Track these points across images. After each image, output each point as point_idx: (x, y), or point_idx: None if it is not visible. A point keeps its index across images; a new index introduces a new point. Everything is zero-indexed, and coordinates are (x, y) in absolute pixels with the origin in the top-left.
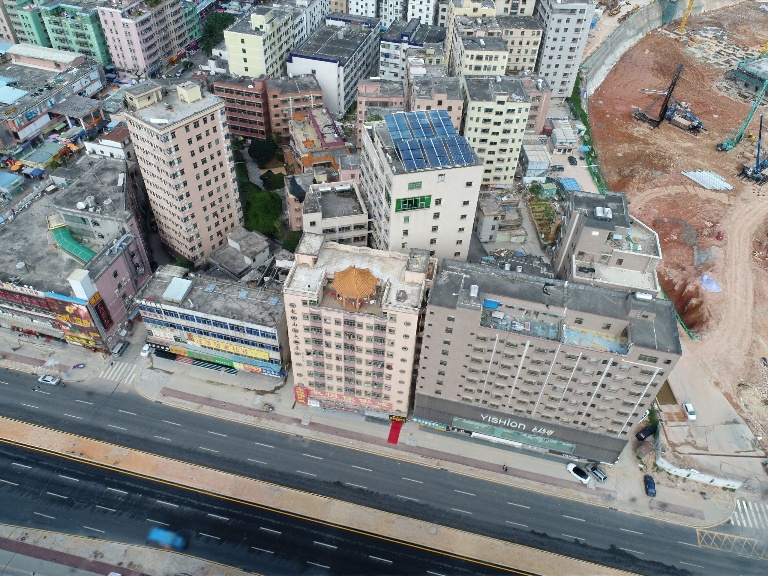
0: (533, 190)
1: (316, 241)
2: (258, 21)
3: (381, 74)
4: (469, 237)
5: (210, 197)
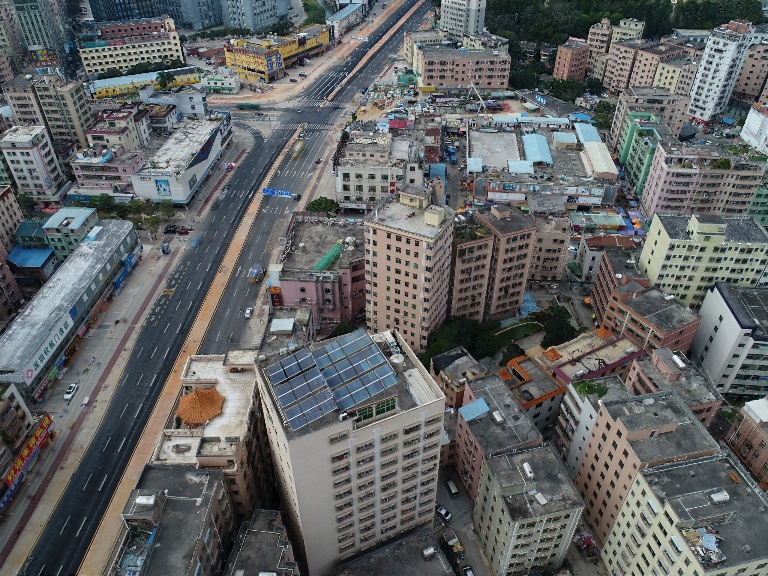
0: None
1: (247, 360)
2: (693, 225)
3: None
4: None
5: (396, 303)
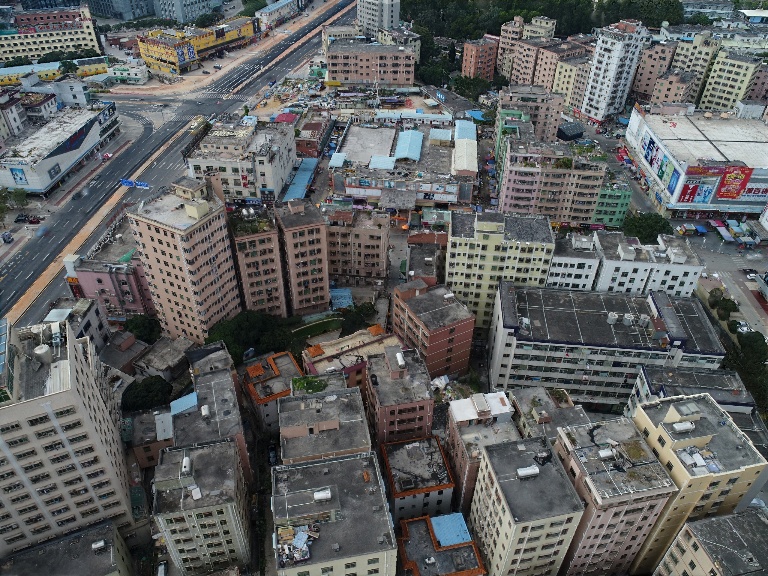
0: None
1: None
2: None
3: (627, 408)
4: None
5: (174, 296)
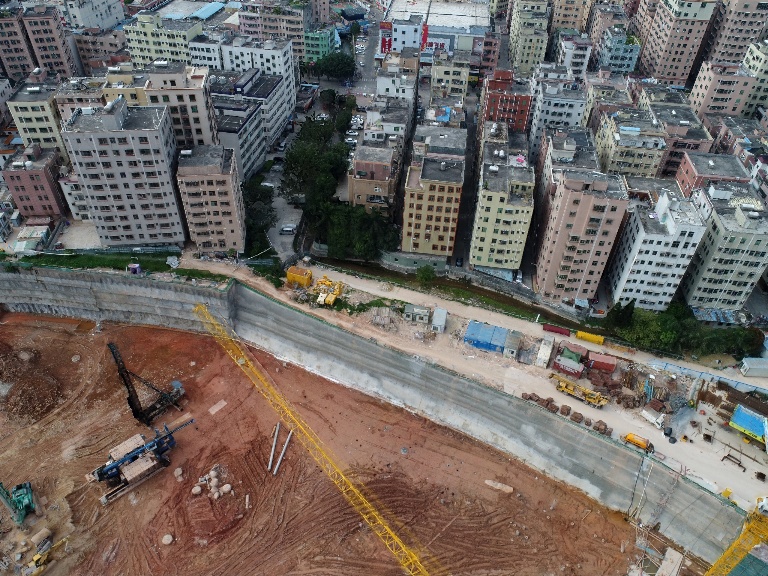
0: None
1: None
2: None
3: None
4: None
5: None
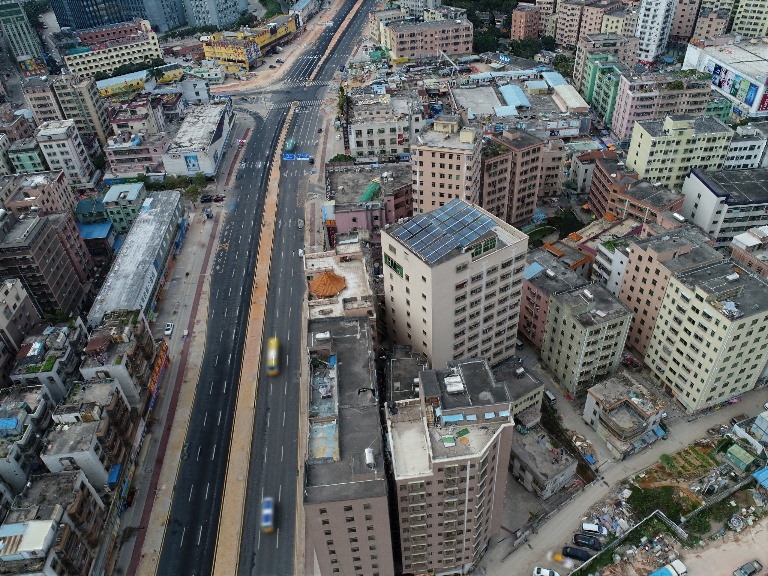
0: (722, 442)
1: (354, 250)
2: (668, 124)
3: None
4: (431, 335)
5: None
